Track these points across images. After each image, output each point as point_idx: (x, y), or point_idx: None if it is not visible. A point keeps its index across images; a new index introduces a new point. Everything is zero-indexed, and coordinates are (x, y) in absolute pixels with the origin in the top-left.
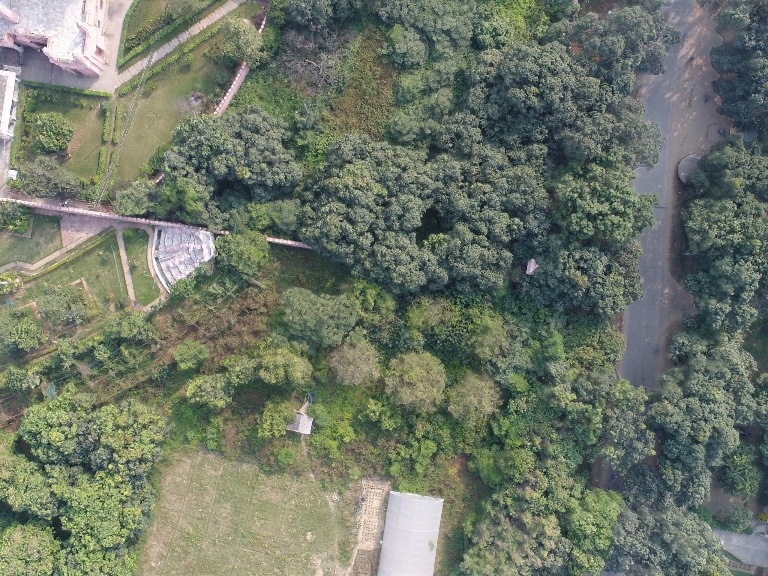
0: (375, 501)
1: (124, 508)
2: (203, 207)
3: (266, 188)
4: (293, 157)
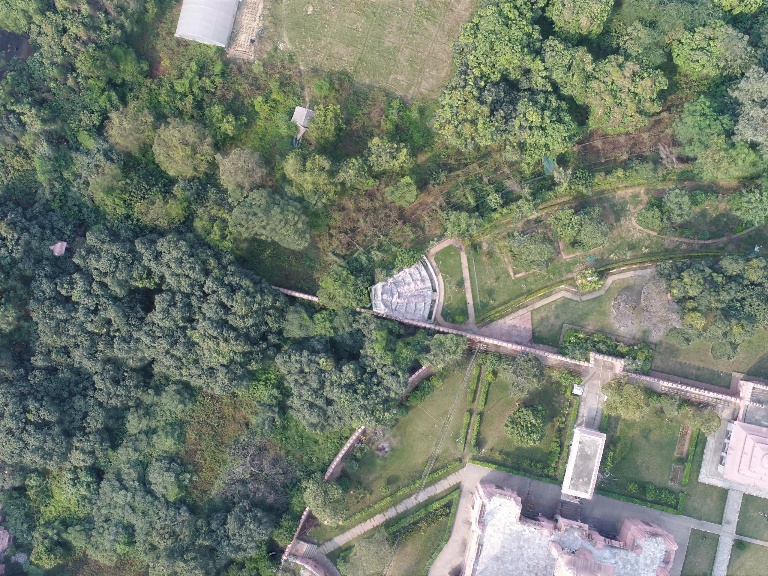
0: (244, 39)
1: (474, 42)
2: None
3: (314, 350)
4: None
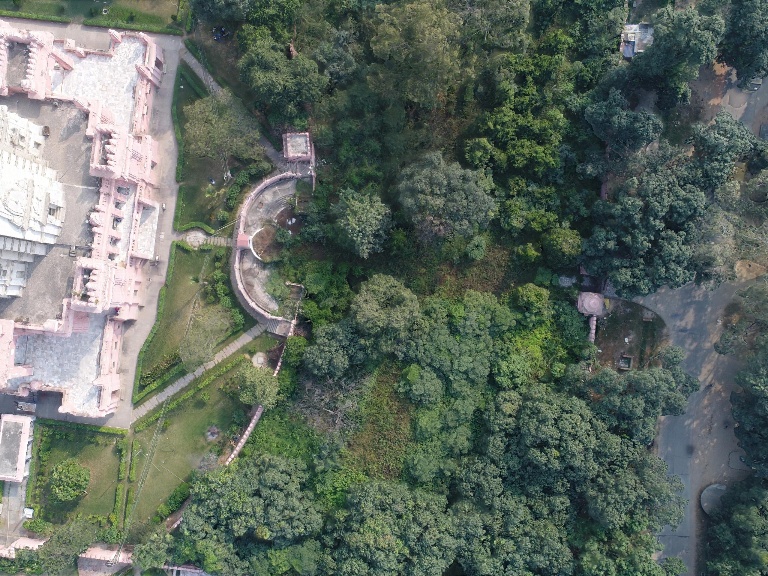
0: None
1: None
2: (223, 563)
3: None
4: (312, 499)
